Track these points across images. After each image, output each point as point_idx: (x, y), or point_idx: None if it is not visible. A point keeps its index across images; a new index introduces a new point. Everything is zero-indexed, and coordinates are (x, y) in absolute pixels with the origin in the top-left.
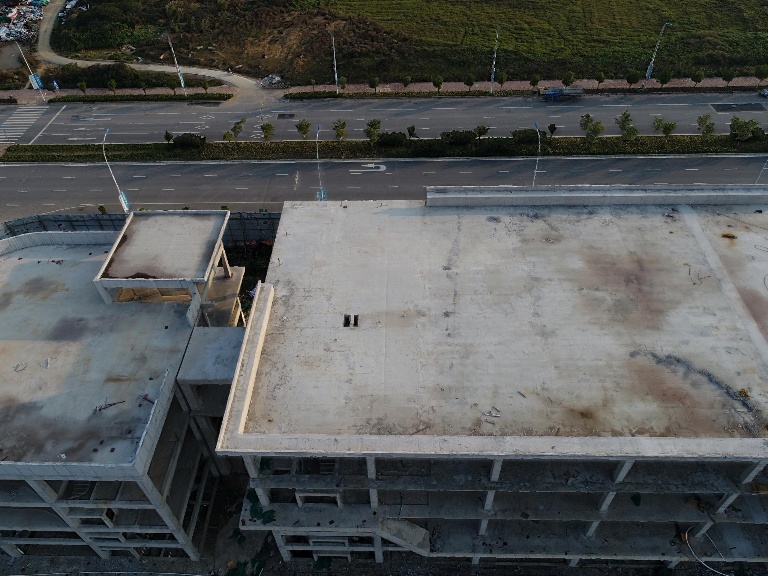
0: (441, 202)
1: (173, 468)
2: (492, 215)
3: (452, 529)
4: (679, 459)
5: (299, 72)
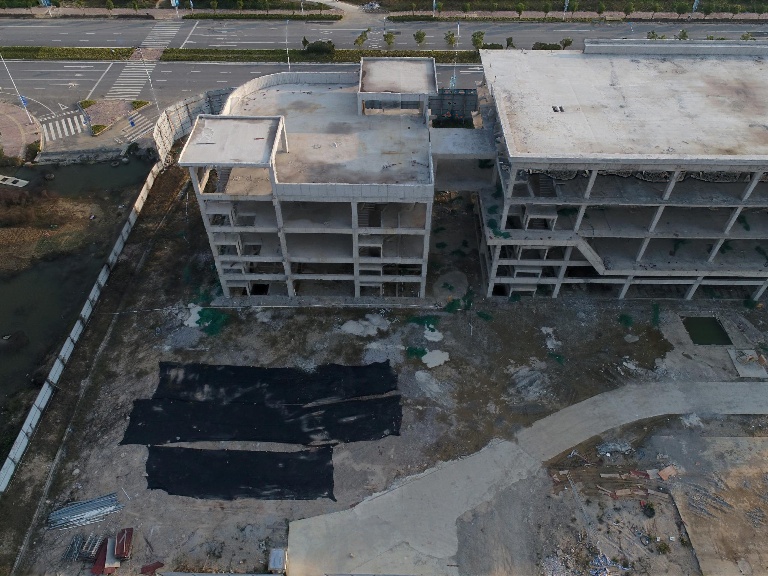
0: (595, 50)
1: None
2: (633, 59)
3: (617, 259)
4: None
5: (394, 1)
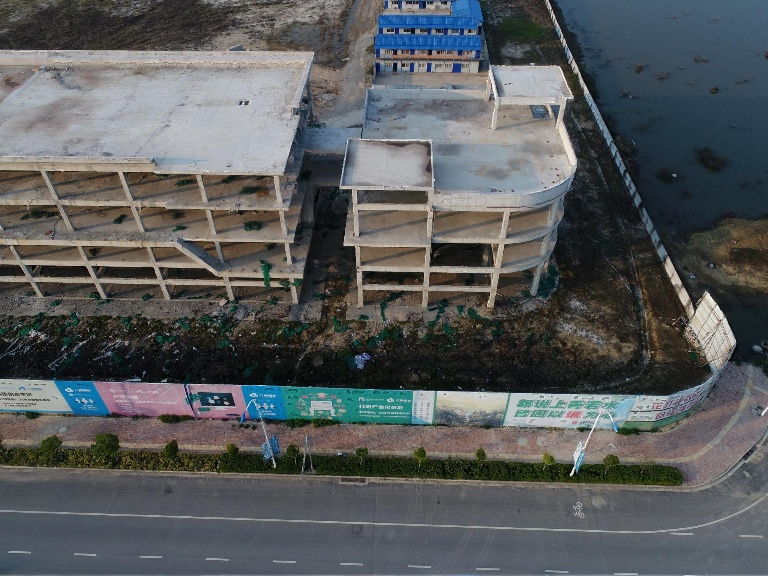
0: None
1: None
2: None
3: None
4: None
5: None
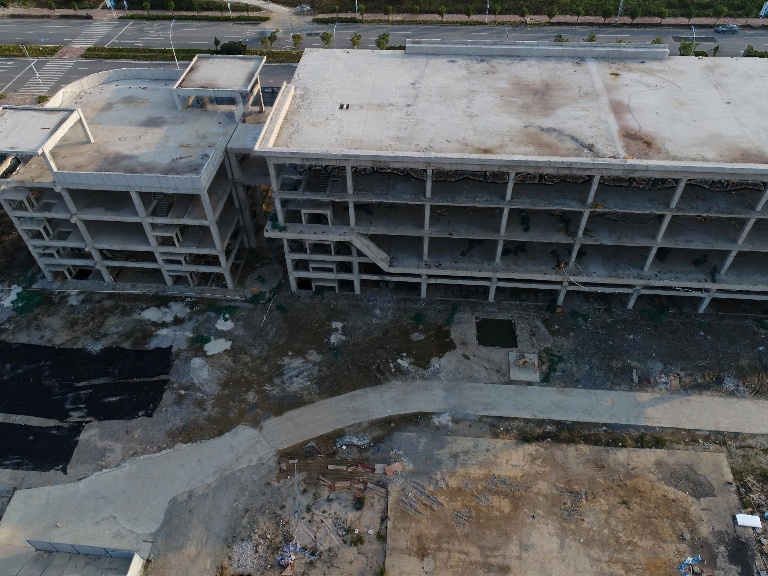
0: (416, 50)
1: (221, 206)
2: (451, 59)
3: (406, 257)
4: (535, 163)
5: (326, 3)
